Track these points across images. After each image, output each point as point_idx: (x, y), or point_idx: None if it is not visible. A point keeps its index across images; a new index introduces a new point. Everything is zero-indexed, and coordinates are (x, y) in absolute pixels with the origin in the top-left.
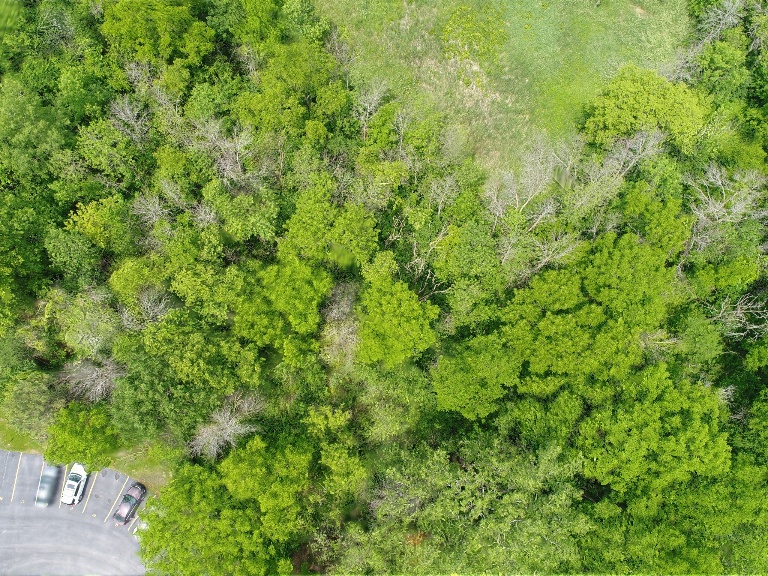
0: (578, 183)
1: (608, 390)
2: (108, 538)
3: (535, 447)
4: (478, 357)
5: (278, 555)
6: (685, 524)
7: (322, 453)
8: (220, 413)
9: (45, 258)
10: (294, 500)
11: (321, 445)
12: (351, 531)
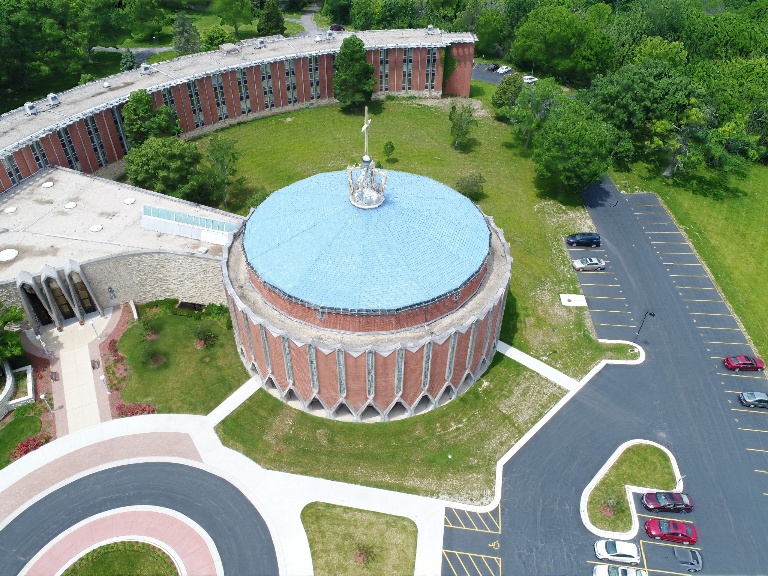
0: None
1: None
2: (485, 73)
3: None
4: None
5: None
6: None
7: None
8: None
9: (464, 5)
10: None
11: None
12: None
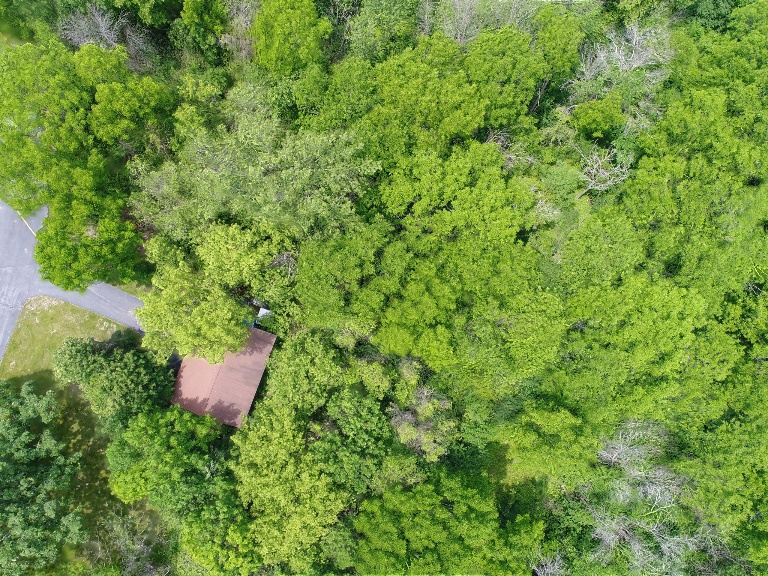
0: (513, 0)
1: (433, 133)
2: None
3: (340, 132)
4: (337, 62)
5: (94, 145)
6: (441, 259)
7: (179, 108)
8: (103, 18)
9: None
10: (130, 115)
11: (182, 104)
12: (166, 163)
